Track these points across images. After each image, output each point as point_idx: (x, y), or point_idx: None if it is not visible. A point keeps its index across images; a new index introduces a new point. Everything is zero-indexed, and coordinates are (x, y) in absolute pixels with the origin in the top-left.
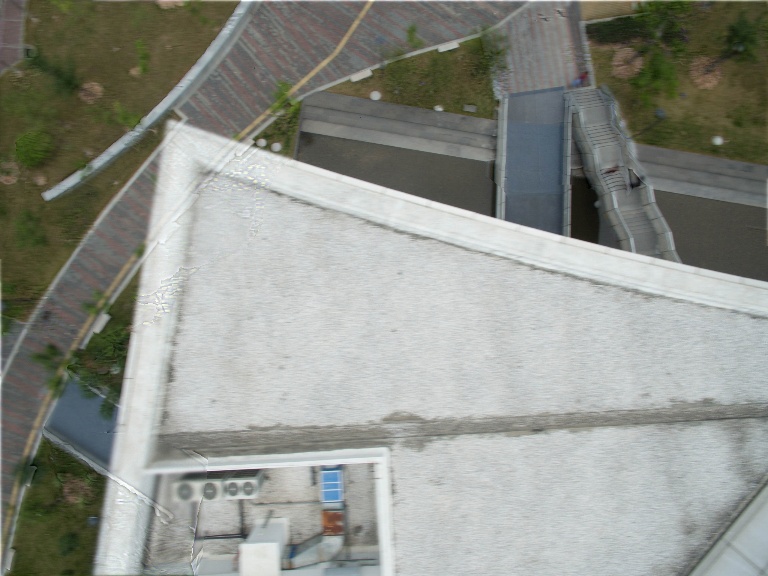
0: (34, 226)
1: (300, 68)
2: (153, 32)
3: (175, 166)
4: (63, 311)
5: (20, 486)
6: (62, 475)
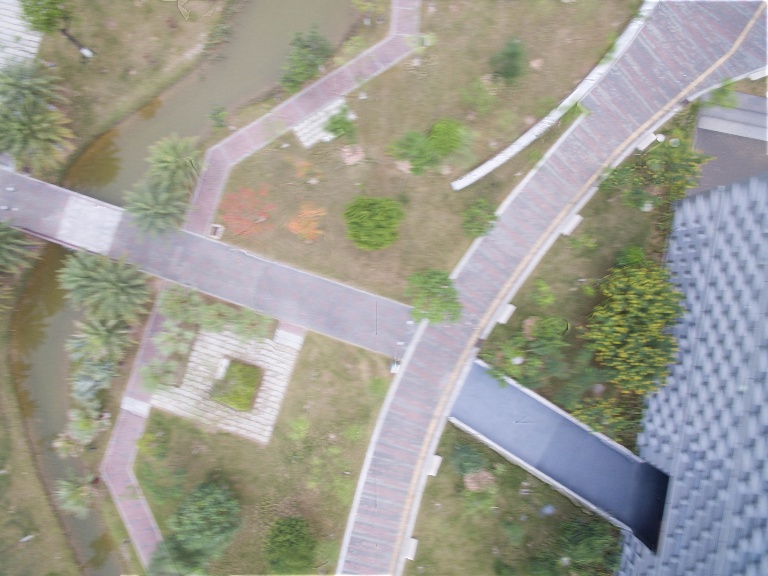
0: (438, 215)
1: (697, 65)
2: (554, 25)
3: (575, 159)
4: (464, 301)
5: (420, 475)
6: (469, 465)
